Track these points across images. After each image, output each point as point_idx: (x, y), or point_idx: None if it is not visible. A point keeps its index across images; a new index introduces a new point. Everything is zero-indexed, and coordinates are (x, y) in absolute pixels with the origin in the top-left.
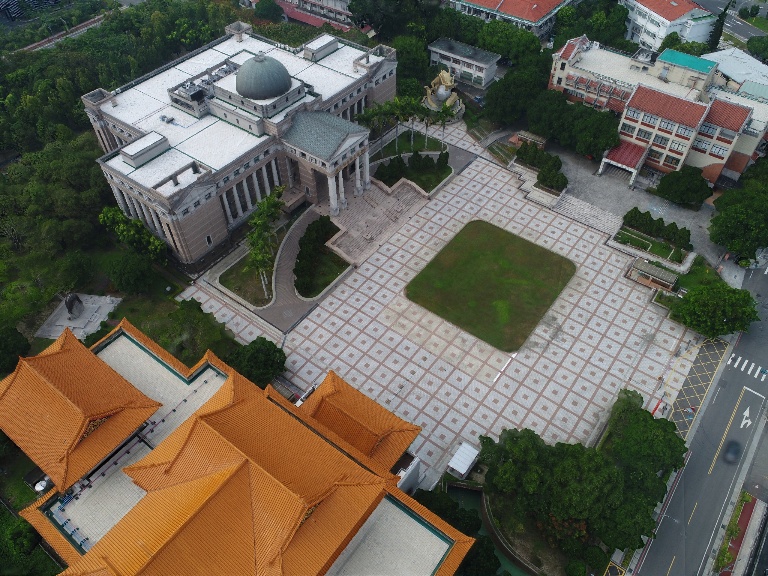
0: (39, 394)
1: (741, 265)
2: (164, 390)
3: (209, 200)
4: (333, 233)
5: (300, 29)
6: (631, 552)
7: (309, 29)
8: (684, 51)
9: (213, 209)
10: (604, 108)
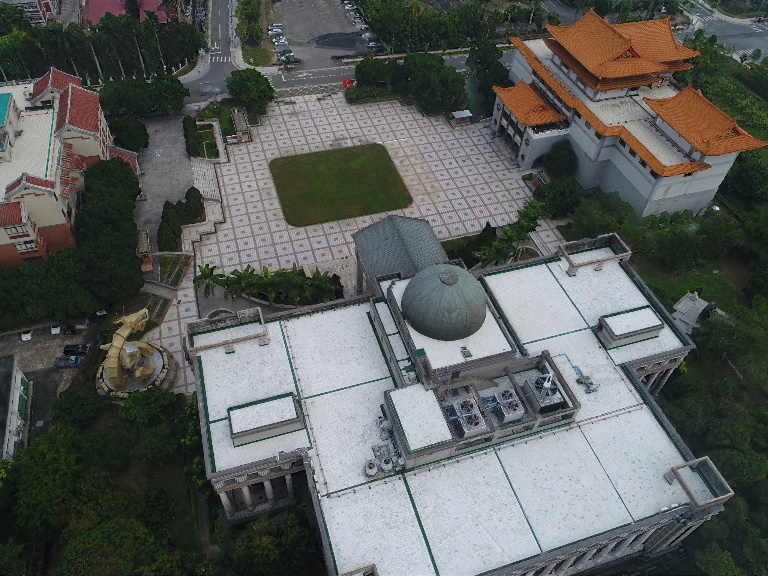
0: None
1: None
2: (638, 131)
3: None
4: None
5: None
6: None
7: None
8: None
9: None
10: None
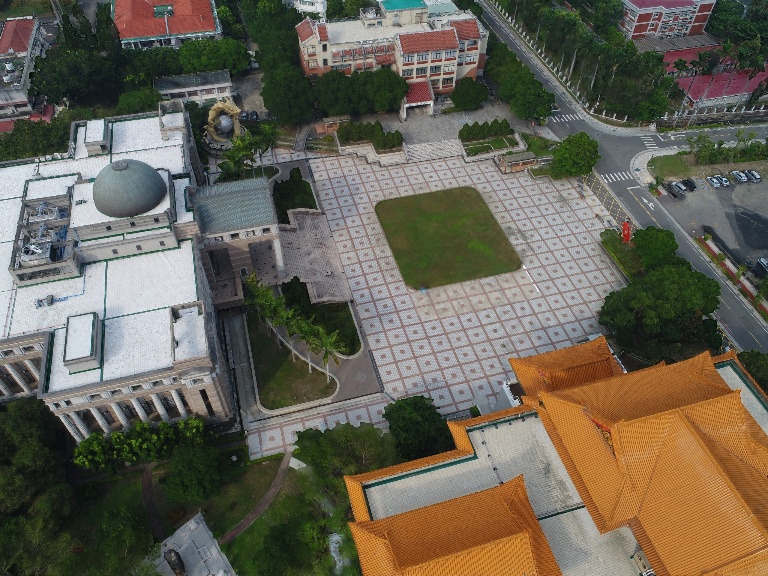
0: (452, 575)
1: (542, 125)
2: (470, 481)
3: (215, 335)
4: (305, 290)
5: None
6: None
7: (5, 136)
8: (366, 2)
9: None
10: (376, 67)
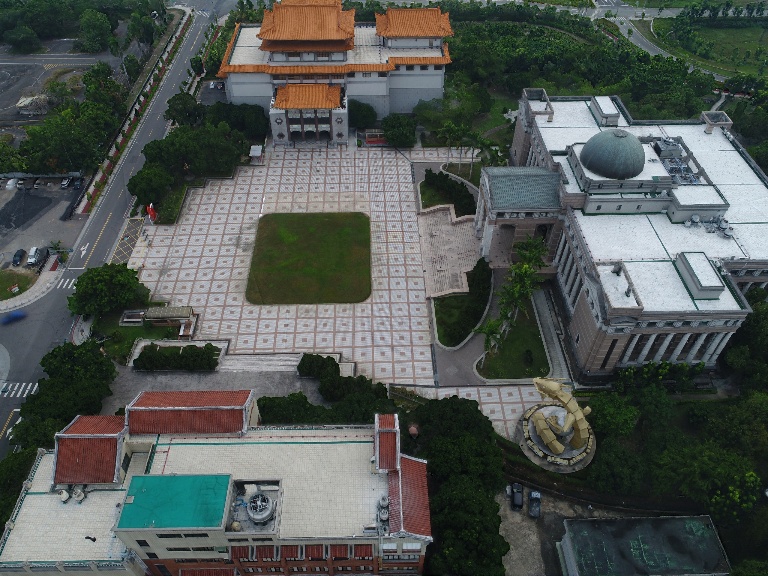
0: None
1: None
2: None
3: None
4: None
5: None
6: None
7: None
8: None
9: None
10: None
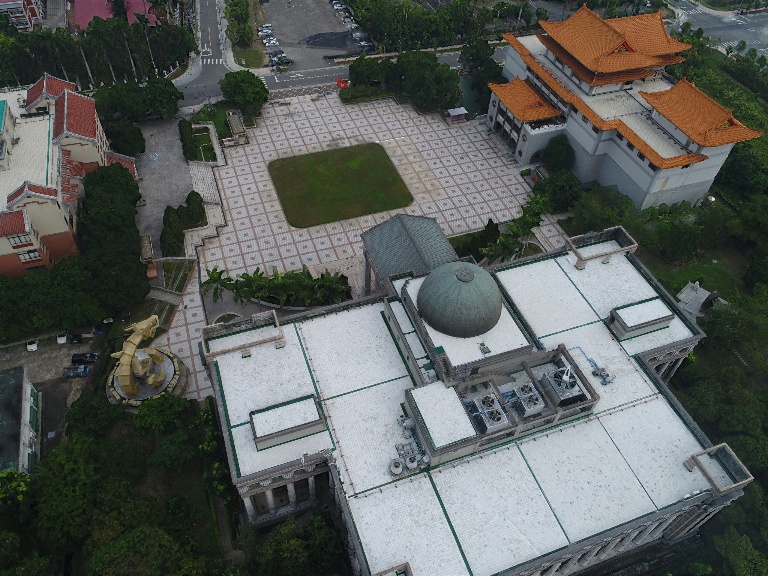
0: None
1: None
2: (634, 124)
3: None
4: None
5: None
6: None
7: None
8: None
9: None
10: None
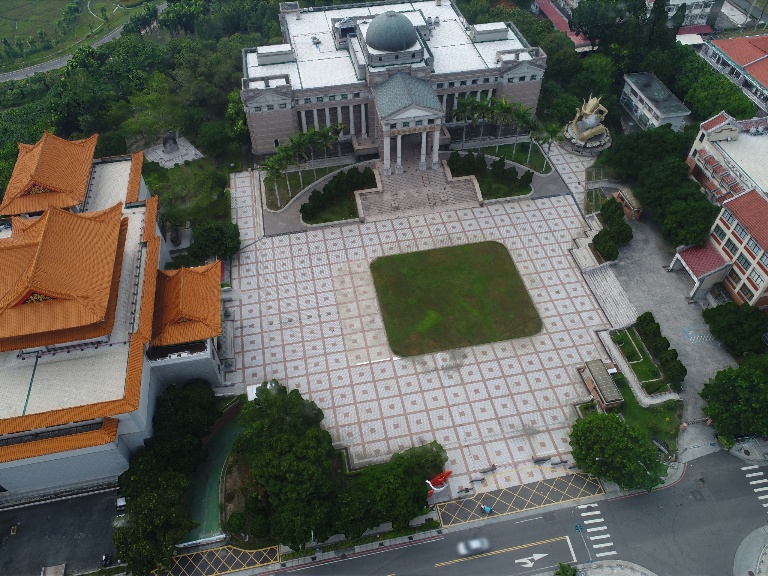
0: None
1: (720, 441)
2: (111, 203)
3: (283, 109)
4: (369, 187)
5: (525, 18)
6: (298, 554)
7: (529, 20)
8: None
9: (286, 119)
10: (716, 201)
